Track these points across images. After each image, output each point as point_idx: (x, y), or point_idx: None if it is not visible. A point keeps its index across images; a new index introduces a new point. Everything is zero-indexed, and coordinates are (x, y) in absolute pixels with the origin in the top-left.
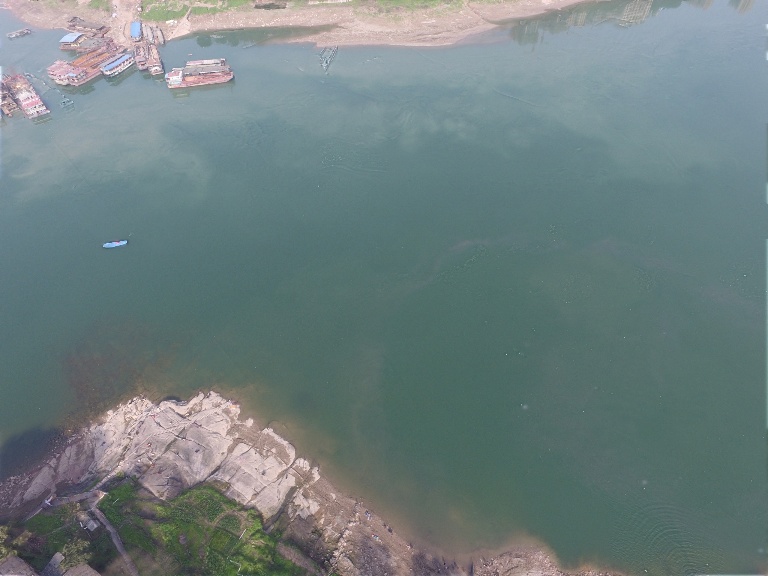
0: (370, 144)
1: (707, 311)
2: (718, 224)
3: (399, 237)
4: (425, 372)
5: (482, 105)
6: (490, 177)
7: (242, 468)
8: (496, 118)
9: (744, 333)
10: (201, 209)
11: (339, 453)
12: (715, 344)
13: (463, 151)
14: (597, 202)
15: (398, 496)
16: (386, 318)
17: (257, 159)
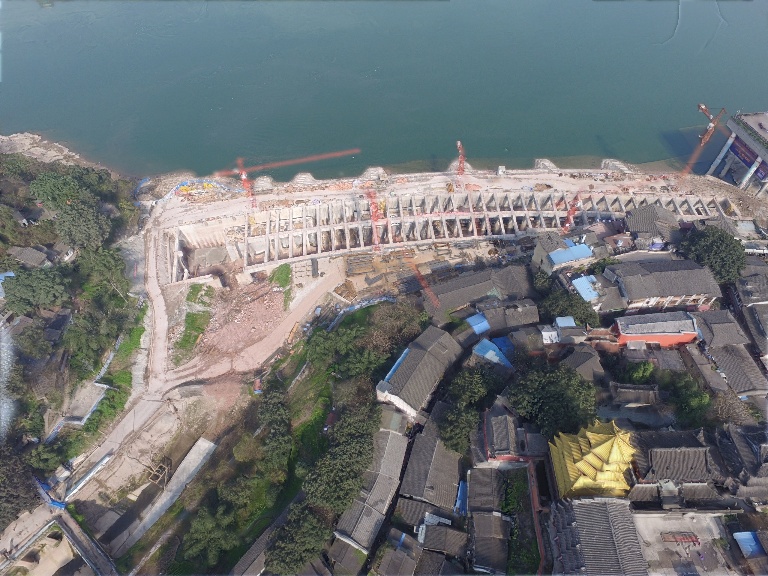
0: (176, 25)
1: (343, 87)
2: (376, 49)
3: (171, 66)
4: (159, 118)
5: (268, 2)
6: (245, 34)
7: (33, 152)
8: (277, 10)
9: (358, 94)
10: (43, 60)
11: (95, 150)
12: (337, 99)
13: (240, 26)
14: (308, 43)
15: (121, 161)
16: (145, 99)
17: (90, 34)
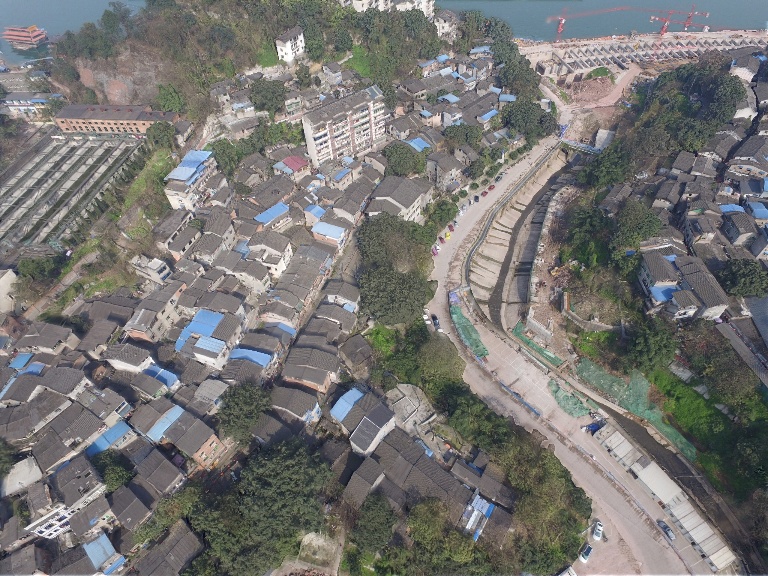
0: None
1: (557, 2)
2: None
3: None
4: None
5: None
6: None
7: None
8: None
9: (570, 5)
10: None
11: None
12: (557, 7)
13: None
14: None
15: None
16: None
17: None
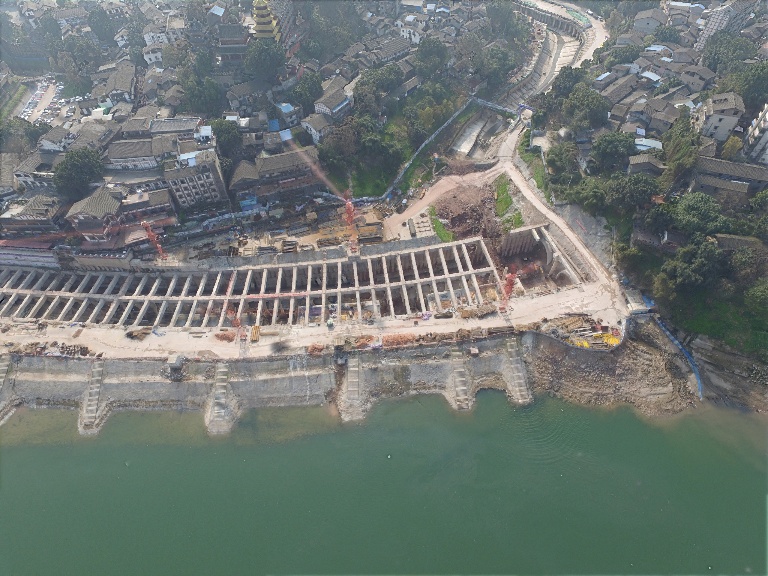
0: None
1: None
2: None
3: None
4: None
5: None
6: None
7: None
8: None
9: None
10: None
11: None
12: None
13: None
14: None
15: None
16: None
17: None
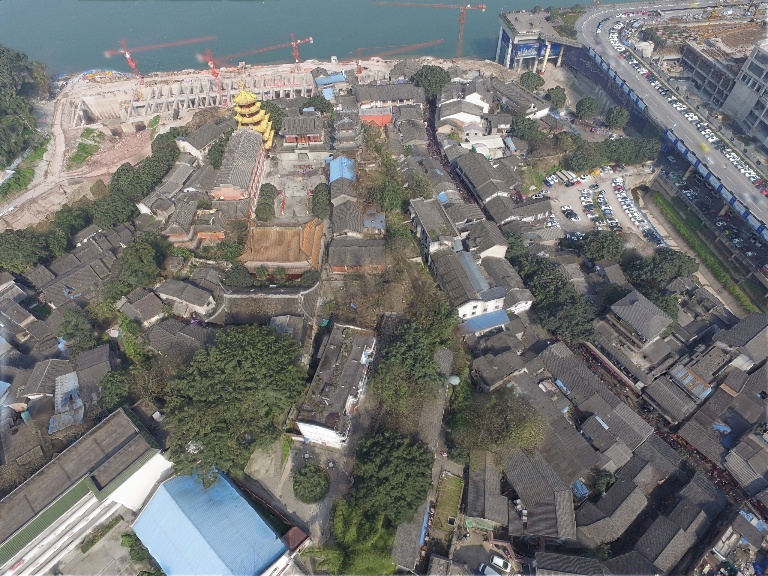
0: None
1: (235, 15)
2: None
3: (96, 2)
4: (80, 37)
5: None
6: None
7: None
8: None
9: (245, 19)
10: None
11: None
12: None
13: None
14: None
15: None
16: (71, 25)
17: None
